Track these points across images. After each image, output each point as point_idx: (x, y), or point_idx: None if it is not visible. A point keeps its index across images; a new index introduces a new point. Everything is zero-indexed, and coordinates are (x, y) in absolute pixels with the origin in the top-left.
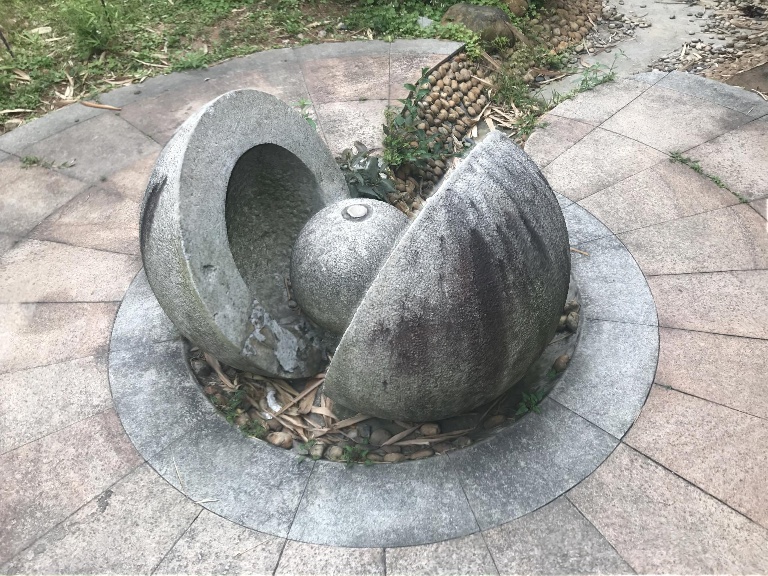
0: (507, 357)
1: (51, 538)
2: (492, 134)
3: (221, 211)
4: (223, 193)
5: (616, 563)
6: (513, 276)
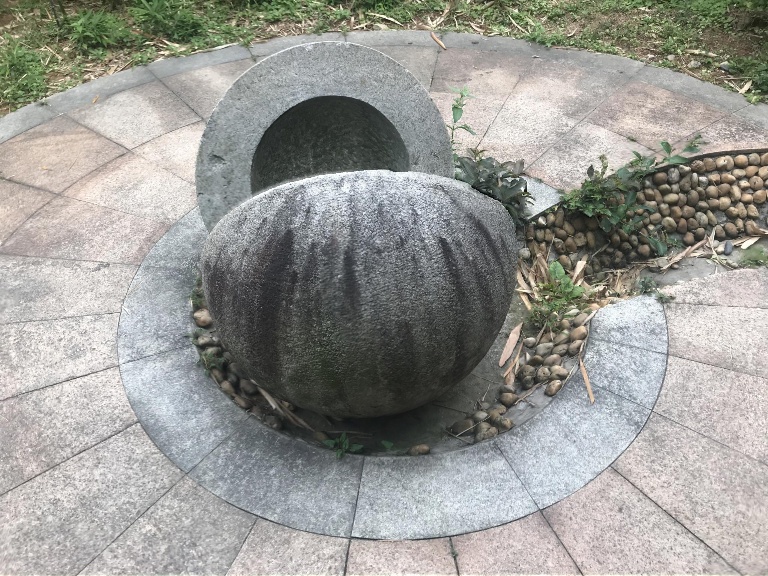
0: (280, 364)
1: (64, 263)
2: (423, 174)
3: (263, 126)
4: (276, 114)
5: None
6: (300, 294)
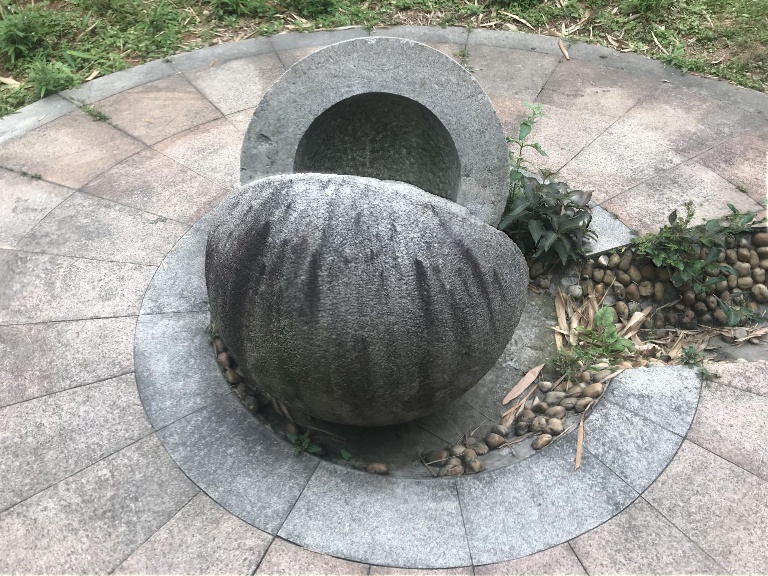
0: (244, 350)
1: (130, 211)
2: (415, 190)
3: (314, 113)
4: (329, 104)
5: (131, 544)
6: (265, 287)
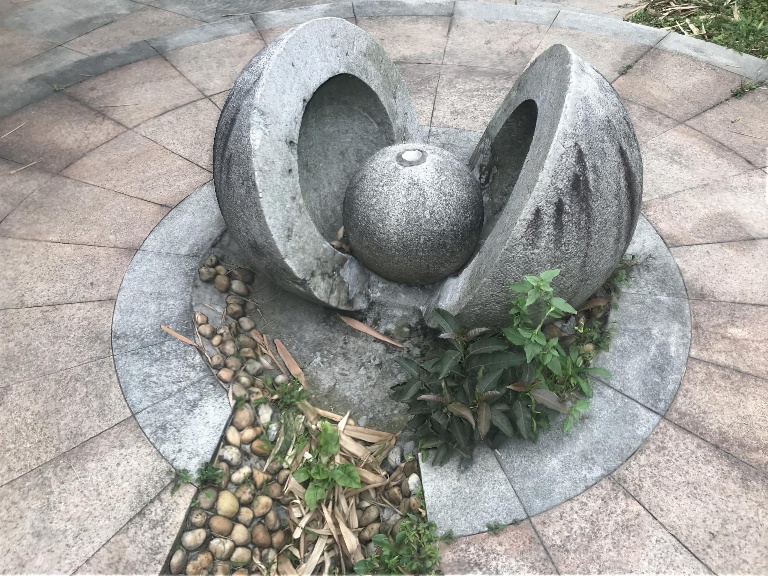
0: None
1: None
2: (272, 63)
3: None
4: None
5: None
6: None
